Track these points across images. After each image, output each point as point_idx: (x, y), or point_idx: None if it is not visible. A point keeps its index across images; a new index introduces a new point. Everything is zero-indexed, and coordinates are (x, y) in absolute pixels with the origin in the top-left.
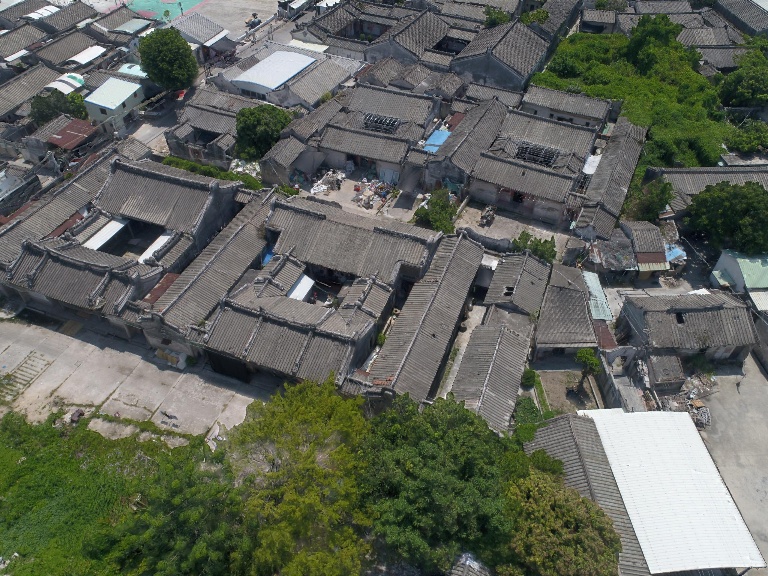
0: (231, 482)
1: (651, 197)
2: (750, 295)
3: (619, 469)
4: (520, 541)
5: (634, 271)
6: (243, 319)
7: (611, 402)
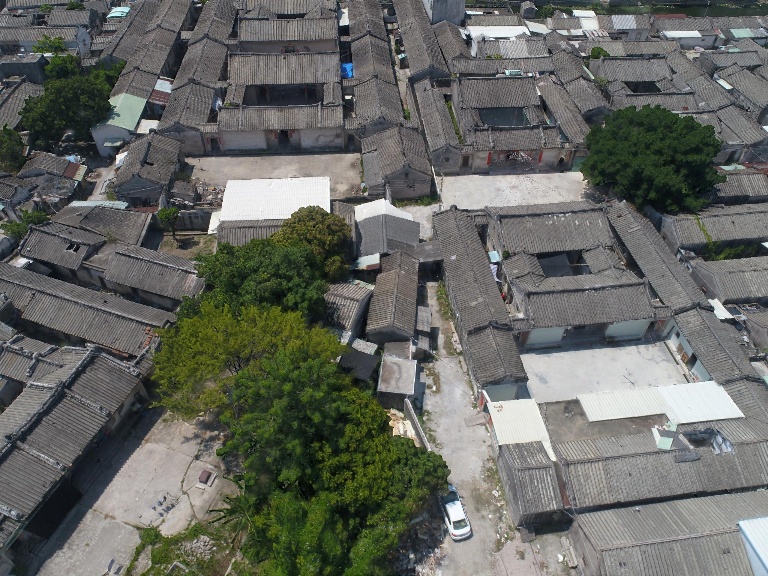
0: (273, 361)
1: (8, 144)
2: (139, 133)
3: (263, 216)
4: (316, 247)
5: (76, 187)
6: (7, 468)
7: (200, 223)
